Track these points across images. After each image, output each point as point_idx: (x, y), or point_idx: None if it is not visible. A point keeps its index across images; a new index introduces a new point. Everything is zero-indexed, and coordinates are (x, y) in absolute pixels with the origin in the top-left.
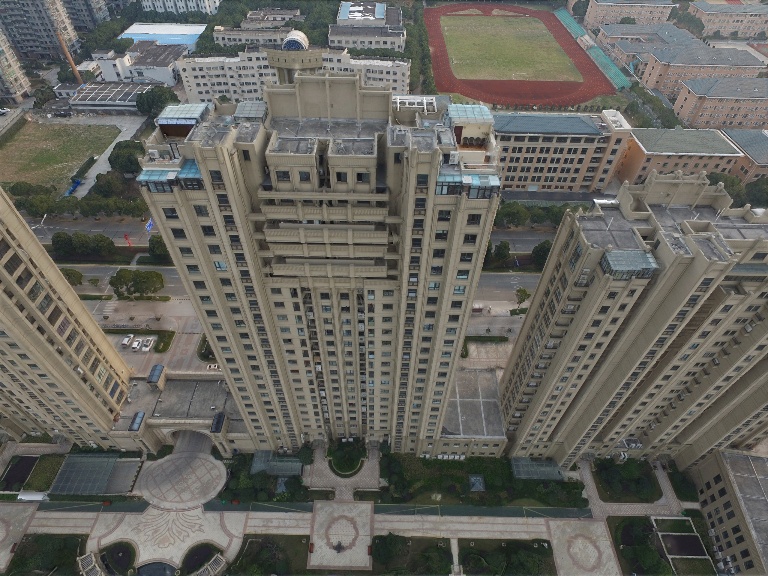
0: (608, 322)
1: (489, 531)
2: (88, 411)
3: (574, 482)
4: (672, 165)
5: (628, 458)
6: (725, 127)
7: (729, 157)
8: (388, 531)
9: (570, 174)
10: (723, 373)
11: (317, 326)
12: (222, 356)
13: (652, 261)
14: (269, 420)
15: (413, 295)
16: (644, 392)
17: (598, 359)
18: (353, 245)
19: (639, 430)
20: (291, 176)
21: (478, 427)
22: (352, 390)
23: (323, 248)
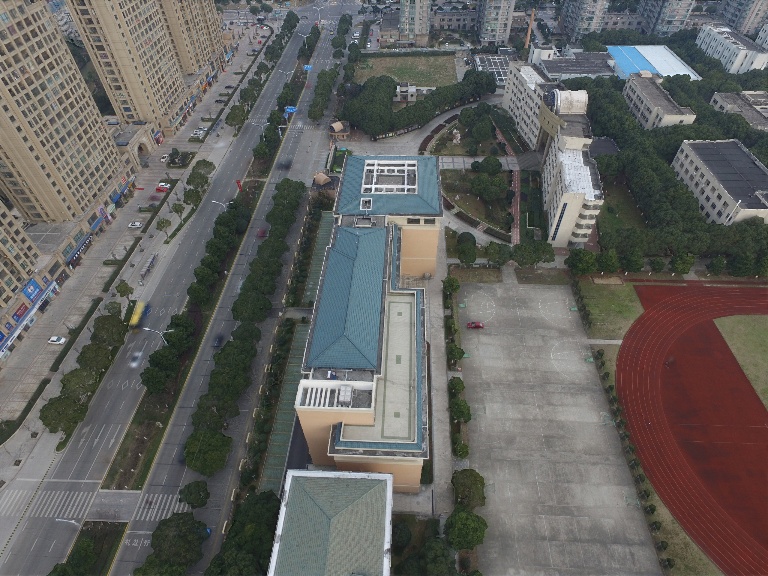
0: None
1: None
2: (111, 101)
3: None
4: None
5: None
6: None
7: None
8: None
9: None
10: None
11: None
12: None
13: None
14: None
15: None
16: None
17: None
18: None
19: None
20: None
21: None
22: None
23: None
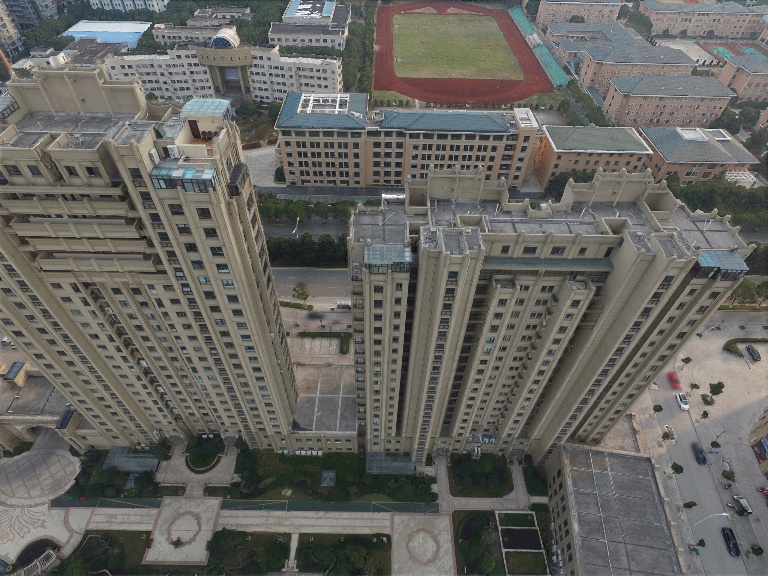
0: (388, 316)
1: (332, 526)
2: None
3: (423, 477)
4: (583, 162)
5: (486, 453)
6: (653, 125)
7: (638, 154)
8: (231, 526)
9: (484, 171)
10: (533, 367)
11: (121, 321)
12: (29, 351)
13: (408, 255)
14: (112, 416)
15: (188, 289)
16: (466, 387)
17: (402, 353)
18: (110, 239)
19: (491, 425)
20: (20, 170)
21: (331, 423)
22: (191, 386)
23: (82, 242)
